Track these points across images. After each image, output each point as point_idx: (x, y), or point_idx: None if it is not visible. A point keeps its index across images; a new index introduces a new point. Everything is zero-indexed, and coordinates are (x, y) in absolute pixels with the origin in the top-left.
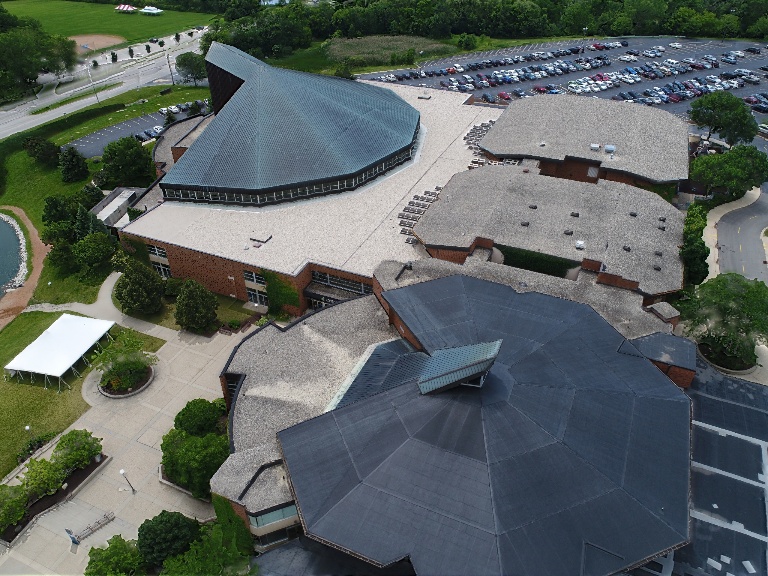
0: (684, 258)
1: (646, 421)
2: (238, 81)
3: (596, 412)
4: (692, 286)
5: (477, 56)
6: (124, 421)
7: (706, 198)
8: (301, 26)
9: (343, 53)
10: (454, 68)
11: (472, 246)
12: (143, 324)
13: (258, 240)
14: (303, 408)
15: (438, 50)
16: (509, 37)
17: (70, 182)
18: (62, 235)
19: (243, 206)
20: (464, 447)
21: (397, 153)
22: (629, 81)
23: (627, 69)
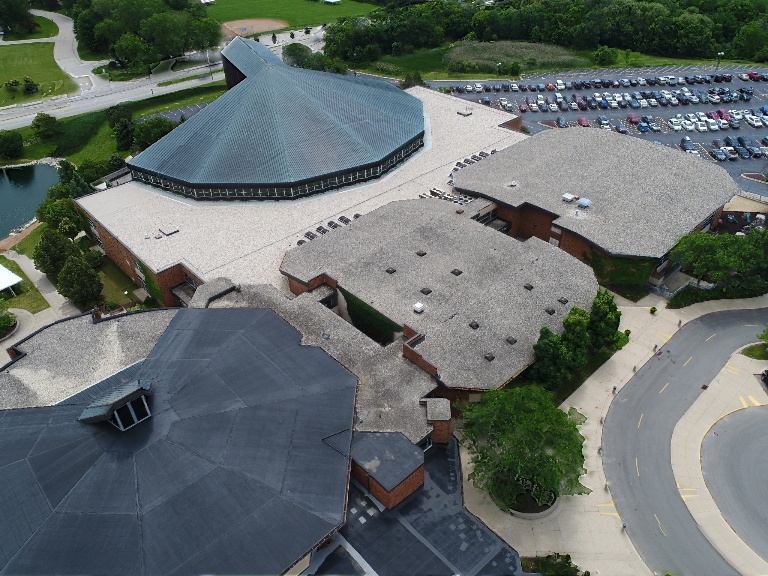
0: (536, 354)
1: (258, 528)
2: (243, 77)
3: (213, 498)
4: (570, 391)
5: (596, 73)
6: None
7: (700, 287)
8: (433, 25)
9: (460, 56)
10: (556, 84)
11: (312, 282)
12: (49, 287)
13: (163, 232)
14: (33, 399)
15: (564, 62)
16: (665, 55)
17: (120, 150)
18: (62, 195)
19: (185, 197)
20: (53, 485)
21: (357, 169)
22: (754, 123)
23: (763, 108)
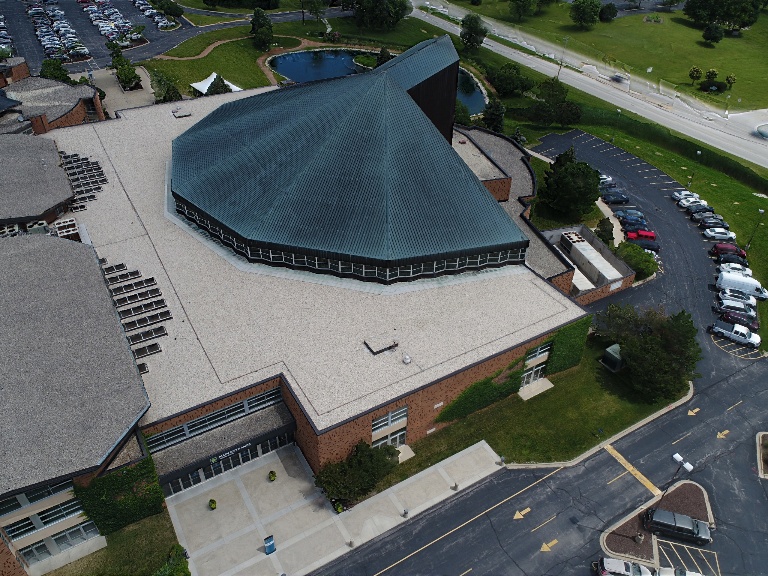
0: None
1: None
2: None
3: None
4: None
5: None
6: (141, 98)
7: None
8: None
9: None
10: None
11: None
12: None
13: None
14: None
15: None
16: None
17: None
18: None
19: None
20: None
21: None
22: None
23: None
